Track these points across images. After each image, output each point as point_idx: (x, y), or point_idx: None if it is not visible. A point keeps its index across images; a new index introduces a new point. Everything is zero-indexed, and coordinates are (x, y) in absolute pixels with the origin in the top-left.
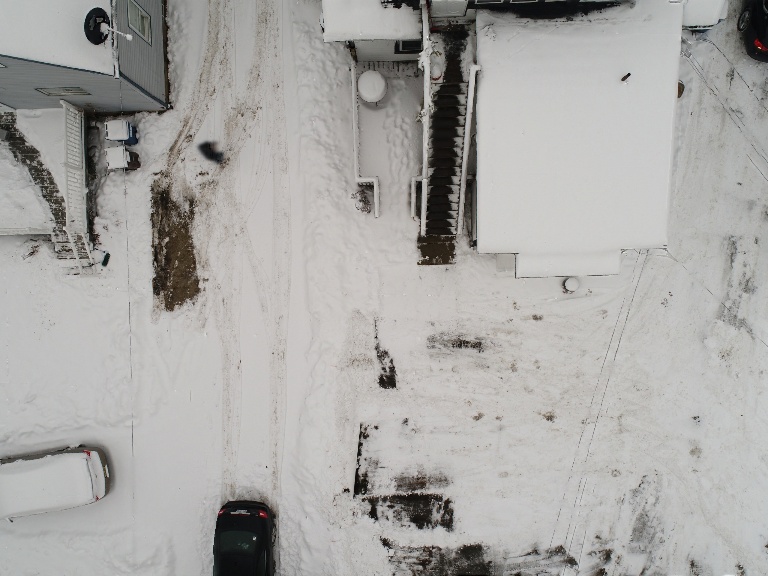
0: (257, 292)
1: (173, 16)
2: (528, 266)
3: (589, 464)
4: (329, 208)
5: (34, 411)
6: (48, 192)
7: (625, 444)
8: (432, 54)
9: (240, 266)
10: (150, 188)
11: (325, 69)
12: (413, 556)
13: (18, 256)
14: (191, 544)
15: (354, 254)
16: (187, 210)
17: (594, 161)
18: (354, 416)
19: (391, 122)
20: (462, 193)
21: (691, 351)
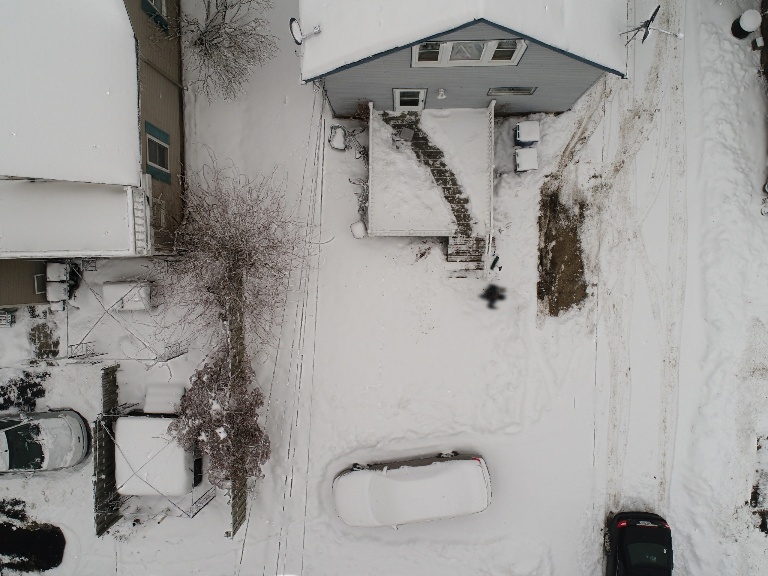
0: (649, 298)
1: None
2: None
3: None
4: (737, 213)
5: (407, 416)
6: (450, 193)
7: None
8: None
9: (632, 271)
10: (540, 190)
11: (733, 71)
12: None
13: (400, 258)
14: (571, 555)
15: (756, 261)
16: (576, 213)
17: None
18: None
19: None
20: None
21: None
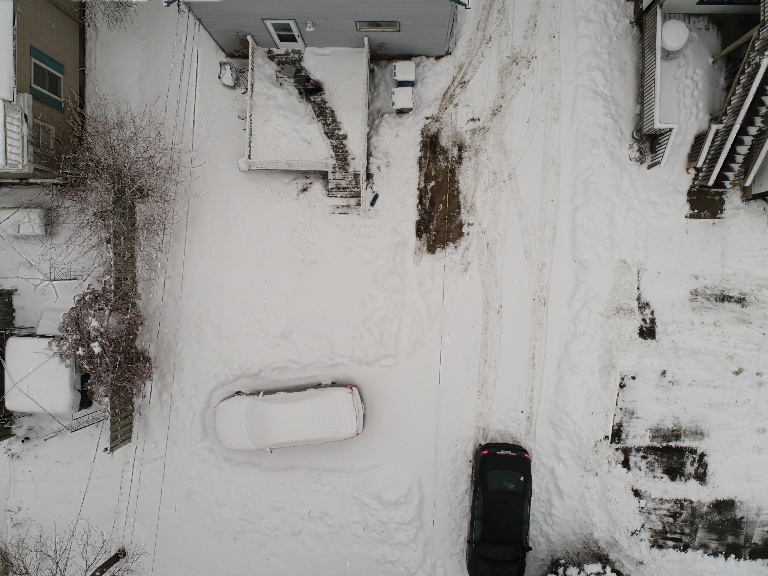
0: (522, 238)
1: None
2: None
3: None
4: (605, 157)
5: (289, 347)
6: (330, 129)
7: None
8: None
9: (506, 212)
10: (420, 132)
11: (606, 21)
12: (664, 508)
13: (285, 193)
14: (440, 485)
15: (624, 204)
16: (455, 155)
17: None
18: None
19: (682, 73)
20: None
21: None
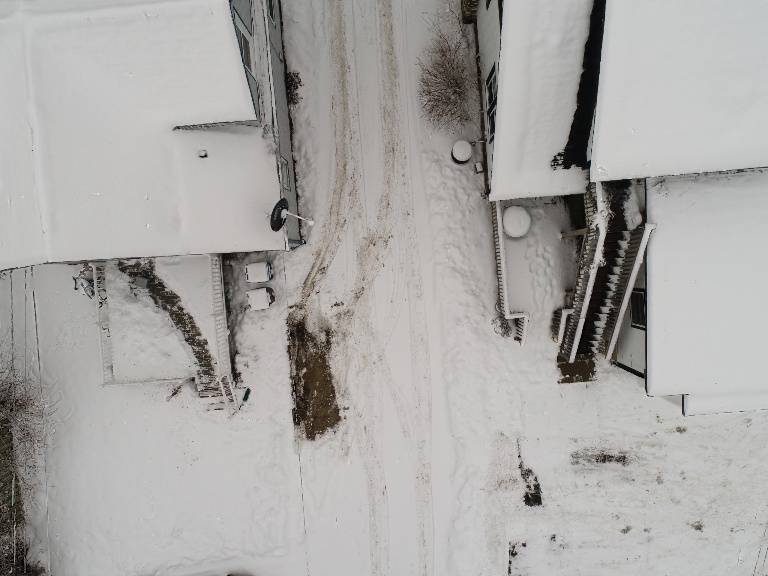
0: (398, 418)
1: (300, 151)
2: (698, 405)
3: (740, 571)
4: (469, 335)
5: (181, 544)
6: (190, 336)
7: None
8: (607, 216)
9: (380, 393)
10: (286, 321)
11: (457, 196)
12: None
13: (158, 395)
14: None
15: (495, 377)
16: (323, 341)
17: (766, 304)
18: (504, 537)
19: (533, 252)
20: (618, 328)
21: None
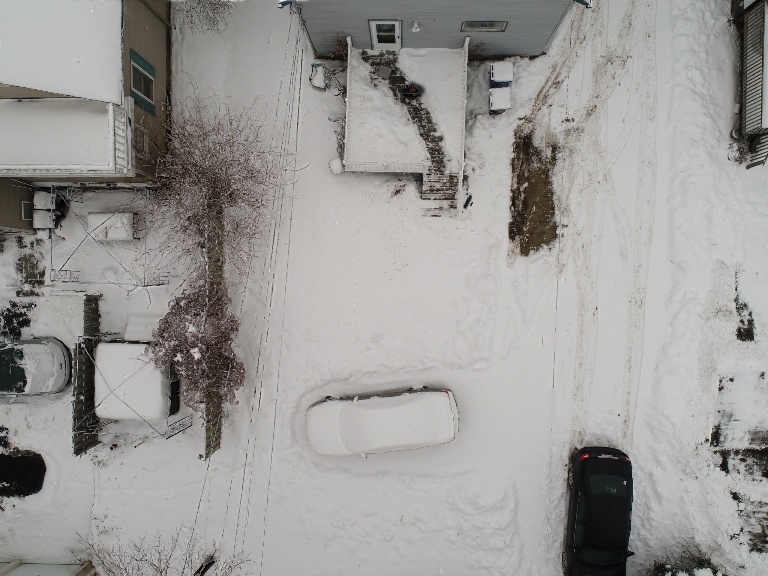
0: (618, 240)
1: None
2: None
3: None
4: (704, 157)
5: (379, 351)
6: (425, 131)
7: None
8: None
9: (601, 213)
10: (513, 133)
11: (703, 19)
12: (763, 511)
13: (376, 196)
14: (536, 489)
15: (722, 205)
16: (549, 156)
17: None
18: None
19: None
20: None
21: None
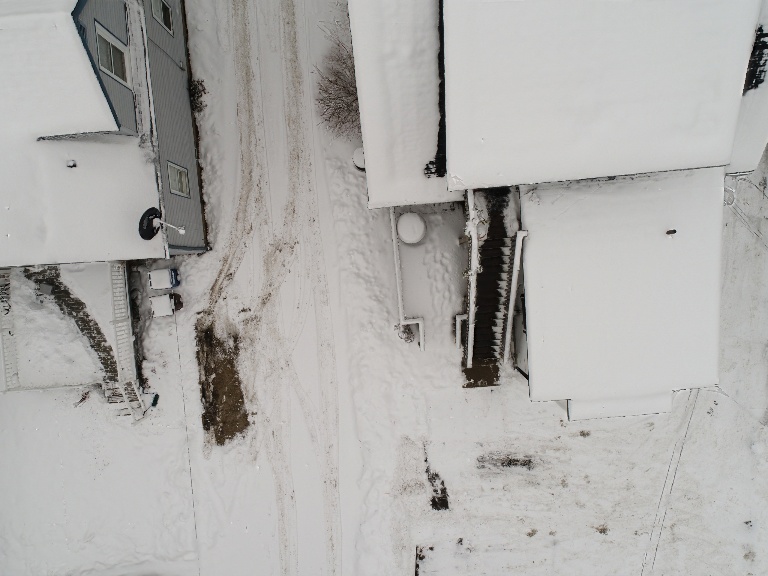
0: (306, 423)
1: (206, 158)
2: (581, 410)
3: (644, 574)
4: (373, 340)
5: (93, 549)
6: (96, 342)
7: (679, 552)
8: (479, 223)
9: (287, 398)
10: (194, 327)
11: (360, 203)
12: None
13: (68, 400)
14: None
15: (400, 382)
16: (232, 346)
17: (643, 310)
18: (410, 541)
19: (431, 258)
20: (509, 333)
21: (739, 457)
